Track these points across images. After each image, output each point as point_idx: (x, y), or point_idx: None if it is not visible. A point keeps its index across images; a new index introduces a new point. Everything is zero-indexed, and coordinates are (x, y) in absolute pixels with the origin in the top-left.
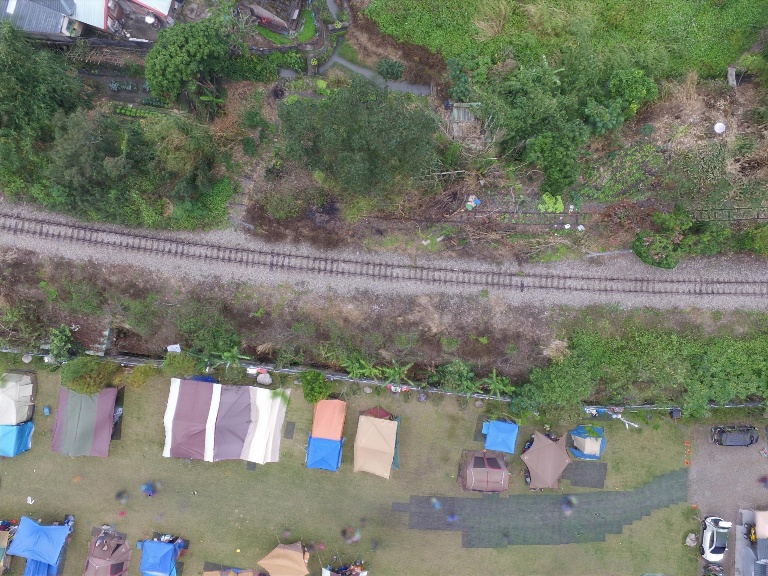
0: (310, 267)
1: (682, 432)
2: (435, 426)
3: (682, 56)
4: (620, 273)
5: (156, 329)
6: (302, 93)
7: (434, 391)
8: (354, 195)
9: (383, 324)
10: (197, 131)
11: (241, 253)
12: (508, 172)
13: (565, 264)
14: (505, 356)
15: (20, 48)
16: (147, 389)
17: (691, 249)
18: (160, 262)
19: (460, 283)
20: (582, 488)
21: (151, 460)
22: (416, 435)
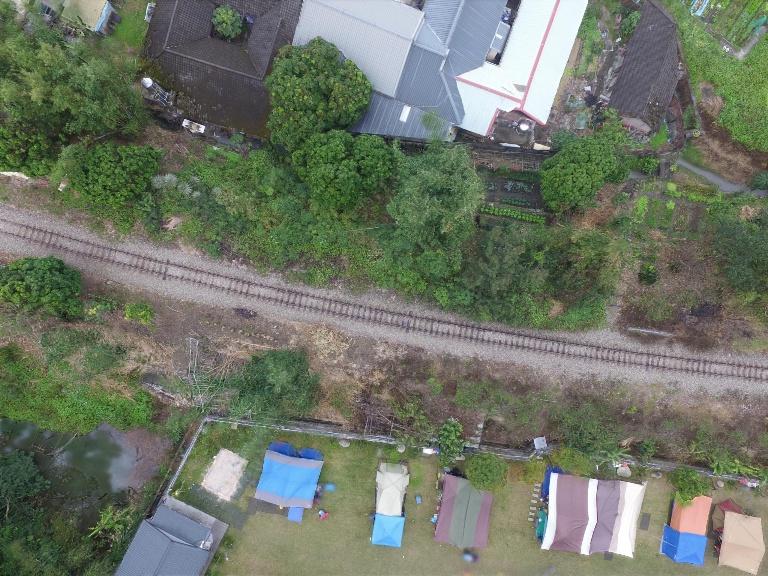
0: (684, 368)
1: None
2: None
3: None
4: None
5: None
6: (650, 194)
7: None
8: (723, 298)
9: (750, 423)
10: None
11: (619, 353)
12: None
13: None
14: None
15: None
16: (511, 479)
17: None
18: (542, 360)
19: None
20: None
21: (514, 549)
22: (765, 528)
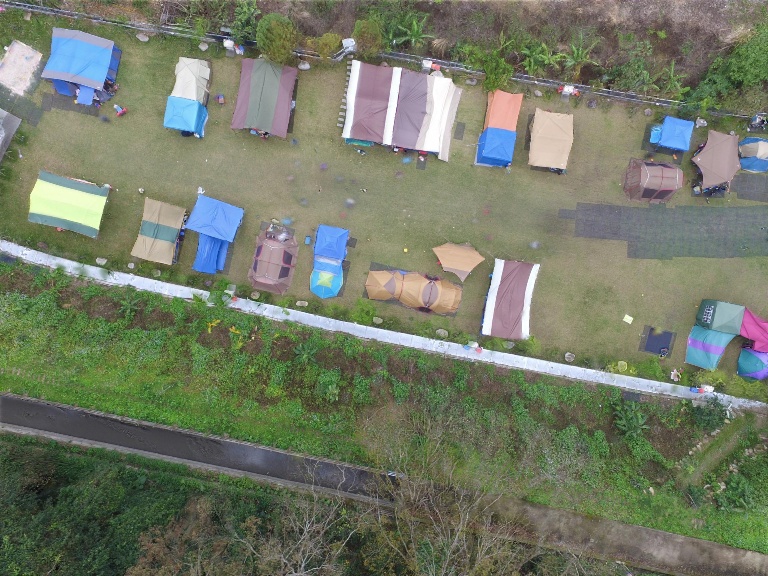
0: None
1: None
2: (604, 133)
3: None
4: None
5: (332, 21)
6: None
7: (608, 90)
8: None
9: (562, 15)
10: None
11: None
12: None
13: None
14: (686, 45)
15: None
16: (320, 84)
17: None
18: None
19: None
20: (748, 201)
21: (322, 155)
22: (584, 142)
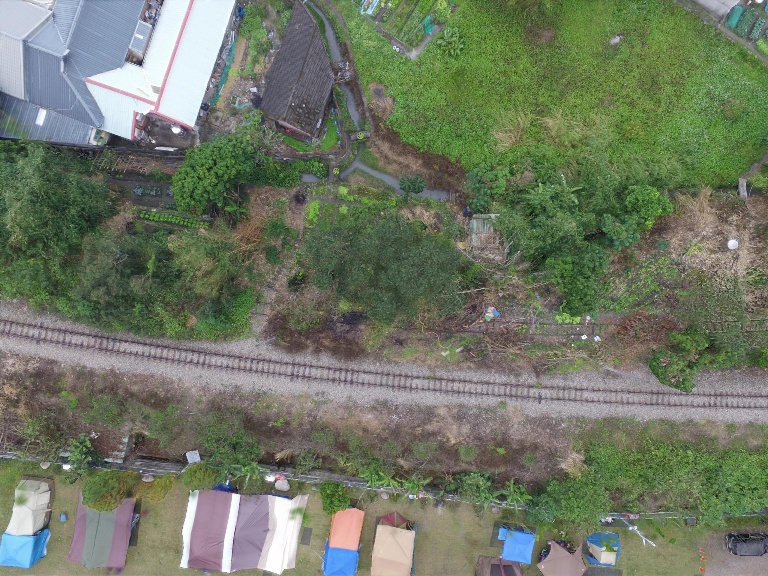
0: (330, 377)
1: (696, 539)
2: (452, 532)
3: (695, 168)
4: (636, 386)
5: (175, 435)
6: (323, 198)
7: (451, 499)
8: None
9: (402, 434)
10: (223, 252)
11: (262, 363)
12: (526, 284)
13: (582, 376)
14: None
15: (53, 177)
16: None
17: (706, 367)
18: (182, 372)
19: (479, 395)
20: None
21: (167, 566)
22: (433, 541)
